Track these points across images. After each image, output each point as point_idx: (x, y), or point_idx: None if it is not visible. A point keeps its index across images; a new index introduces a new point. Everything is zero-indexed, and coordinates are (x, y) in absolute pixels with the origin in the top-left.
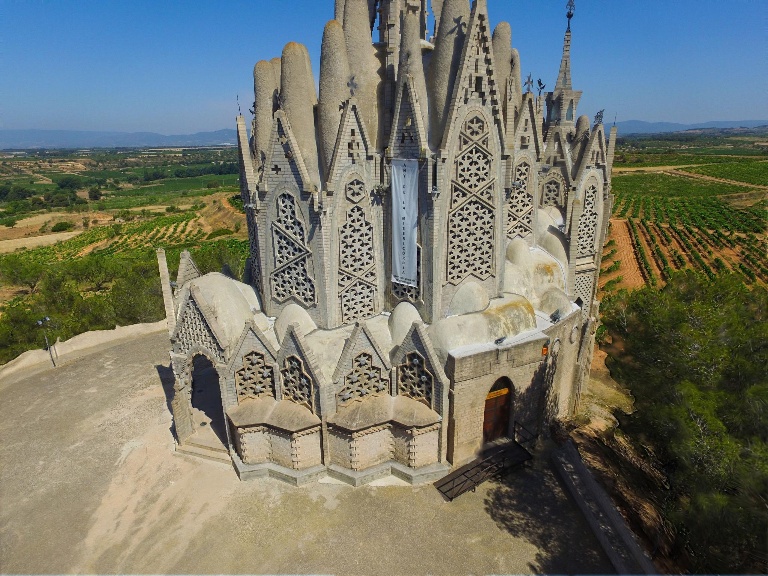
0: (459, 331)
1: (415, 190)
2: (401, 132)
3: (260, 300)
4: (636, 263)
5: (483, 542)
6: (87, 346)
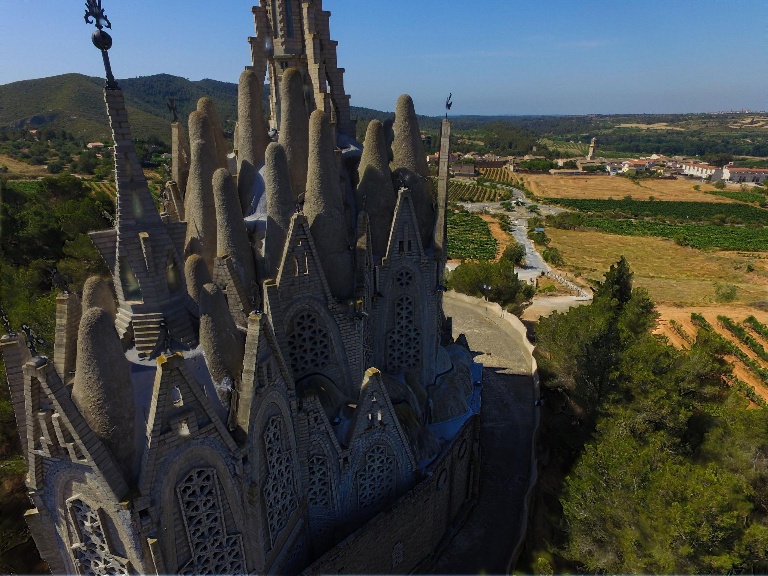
0: None
1: None
2: None
3: None
4: None
5: None
6: None
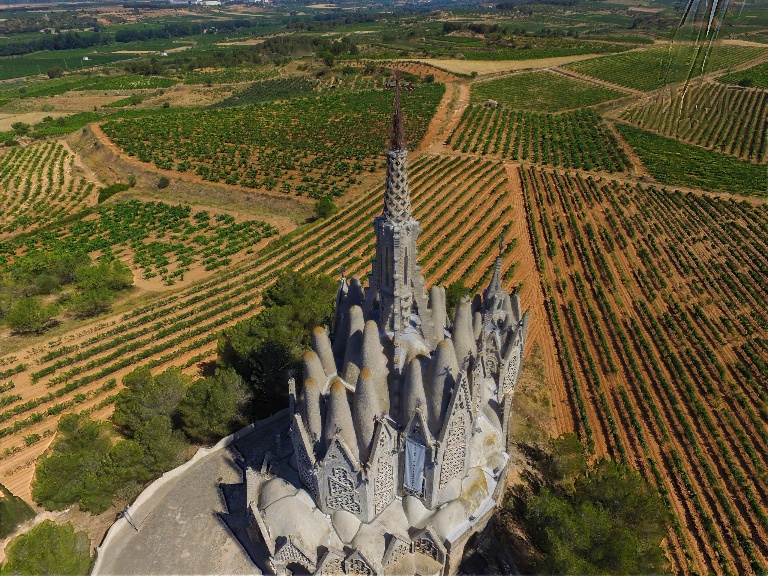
0: (450, 522)
1: (423, 458)
2: (413, 428)
3: (314, 500)
4: (528, 234)
5: None
6: (147, 498)
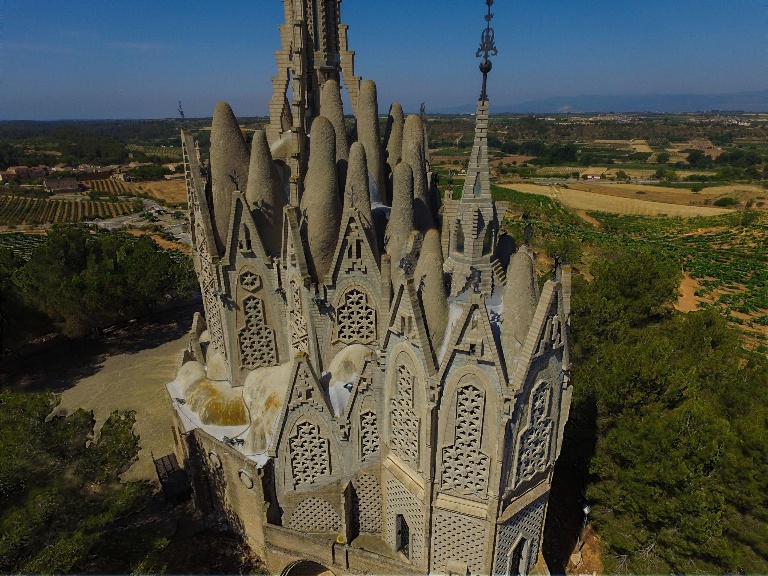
0: (185, 374)
1: None
2: None
3: None
4: None
5: None
6: None
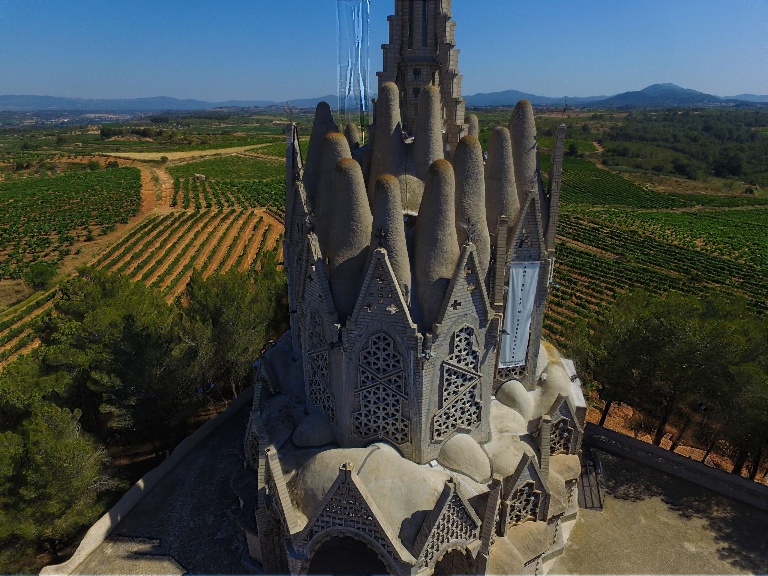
0: None
1: (534, 287)
2: (520, 239)
3: (399, 452)
4: None
5: (646, 517)
6: None
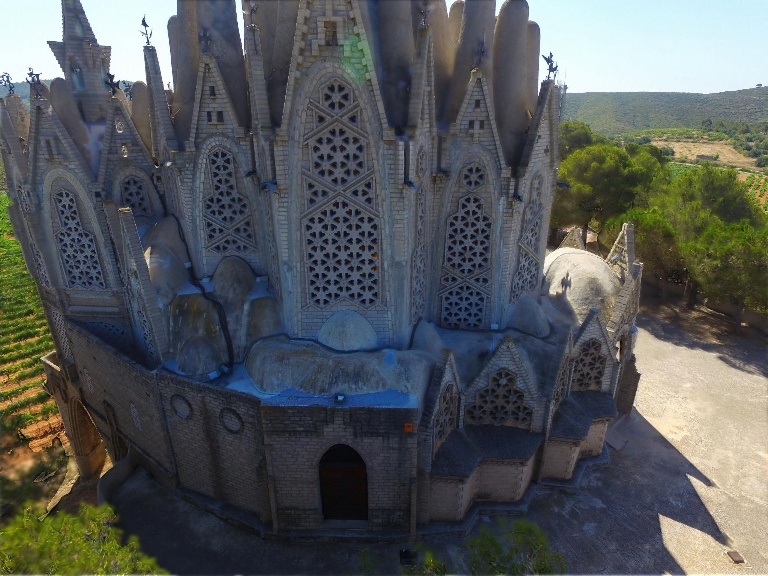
0: None
1: None
2: None
3: None
4: None
5: None
6: None
